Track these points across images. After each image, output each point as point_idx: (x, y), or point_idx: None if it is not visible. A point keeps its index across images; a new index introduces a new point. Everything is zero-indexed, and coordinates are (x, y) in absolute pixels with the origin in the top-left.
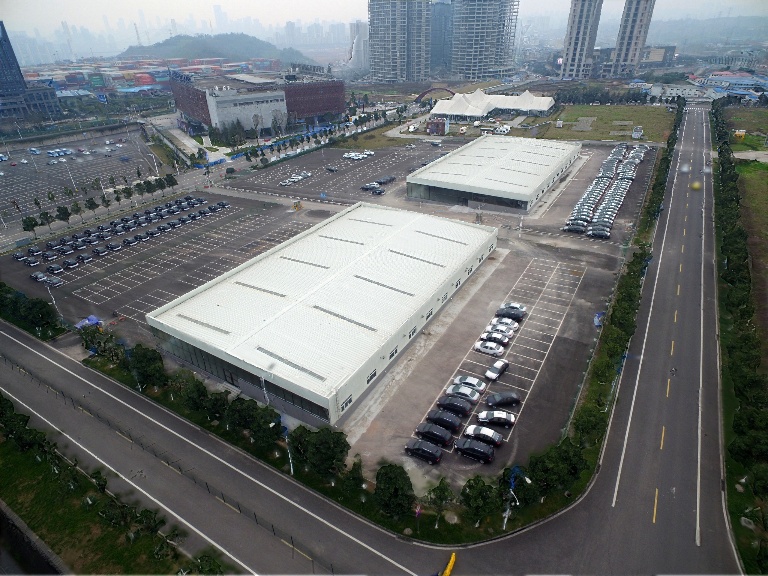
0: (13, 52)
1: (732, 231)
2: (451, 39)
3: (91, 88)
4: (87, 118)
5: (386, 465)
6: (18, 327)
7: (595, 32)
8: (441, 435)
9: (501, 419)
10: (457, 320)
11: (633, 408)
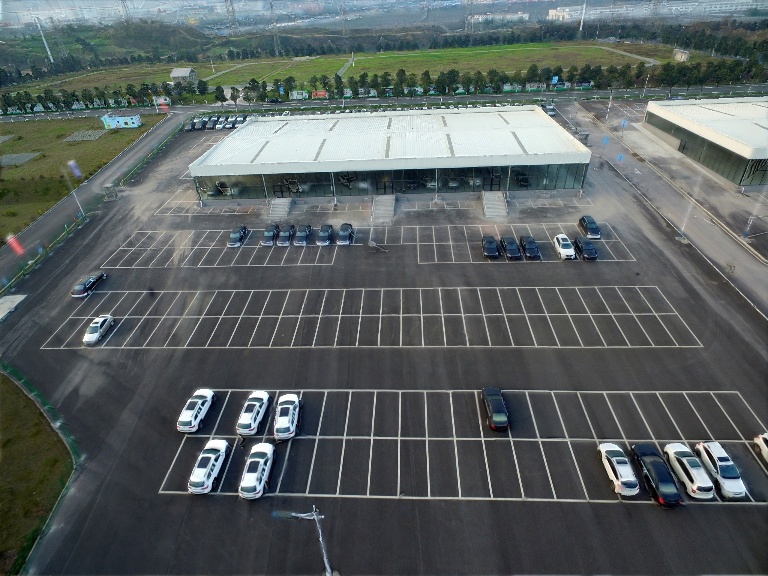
0: None
1: (532, 70)
2: None
3: None
4: None
5: None
6: None
7: None
8: None
9: None
10: None
11: None
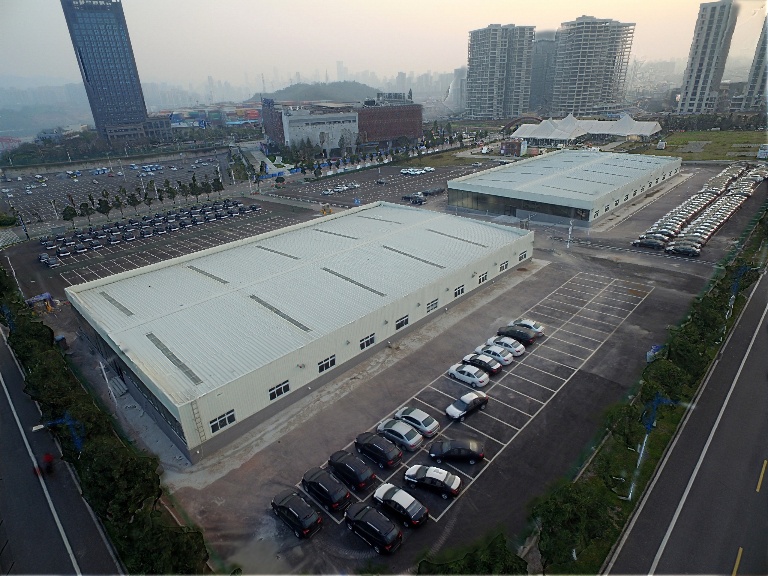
0: None
1: None
2: (553, 76)
3: None
4: (187, 141)
5: (234, 524)
6: None
7: (723, 64)
8: (327, 491)
9: (436, 481)
10: (443, 335)
11: (684, 502)
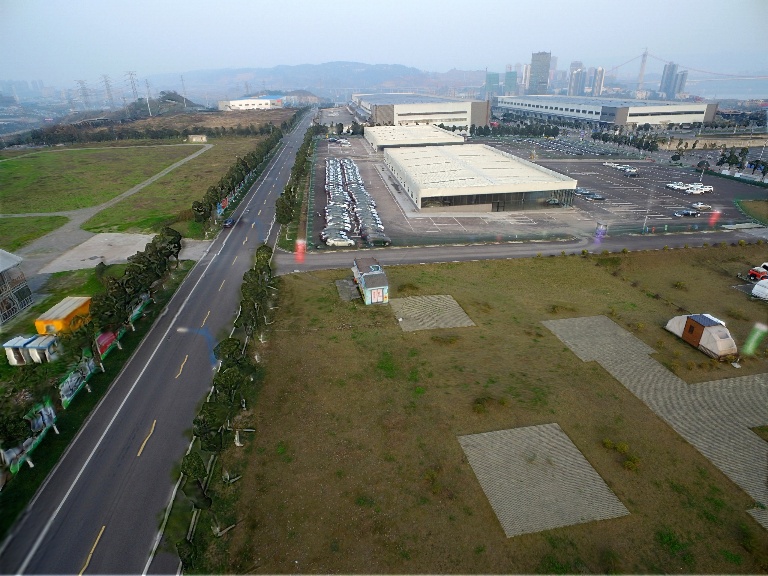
0: None
1: (264, 145)
2: None
3: None
4: None
5: None
6: None
7: None
8: None
9: None
10: None
11: None
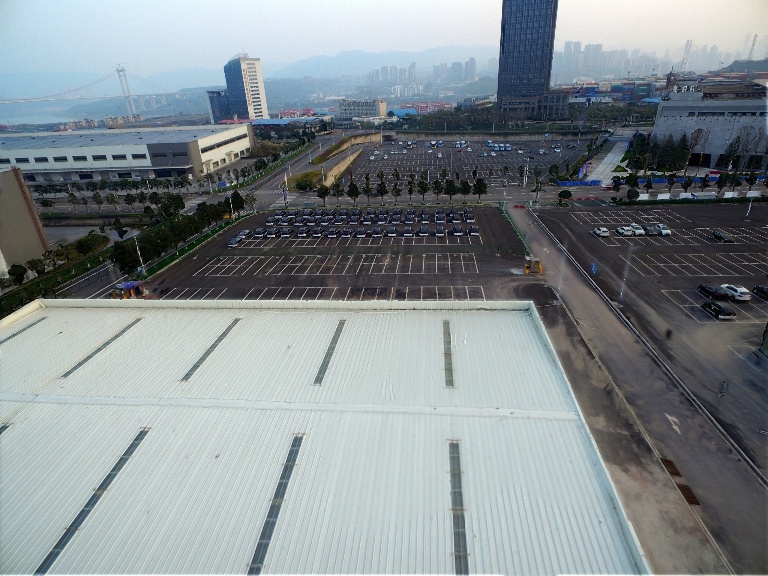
0: (551, 57)
1: None
2: None
3: (615, 96)
4: (563, 121)
5: None
6: (153, 265)
7: None
8: None
9: None
10: None
11: None
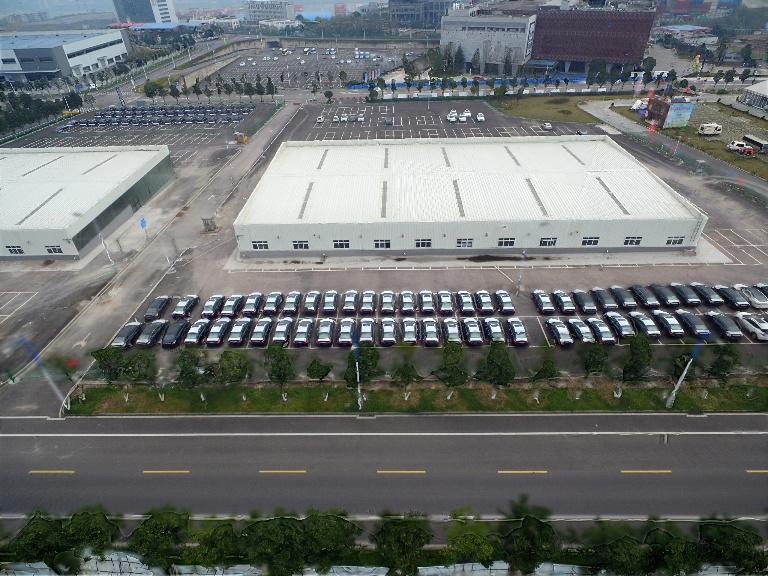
0: None
1: None
2: None
3: None
4: (429, 29)
5: None
6: None
7: None
8: None
9: None
10: None
11: None
